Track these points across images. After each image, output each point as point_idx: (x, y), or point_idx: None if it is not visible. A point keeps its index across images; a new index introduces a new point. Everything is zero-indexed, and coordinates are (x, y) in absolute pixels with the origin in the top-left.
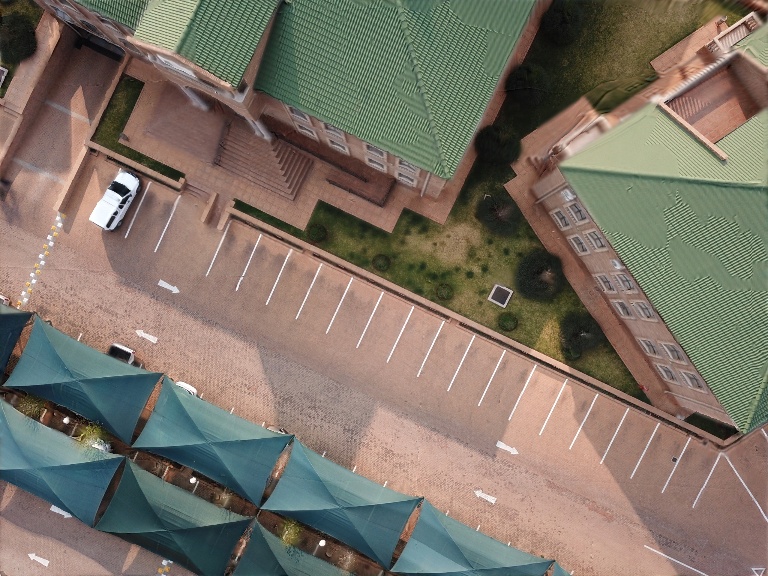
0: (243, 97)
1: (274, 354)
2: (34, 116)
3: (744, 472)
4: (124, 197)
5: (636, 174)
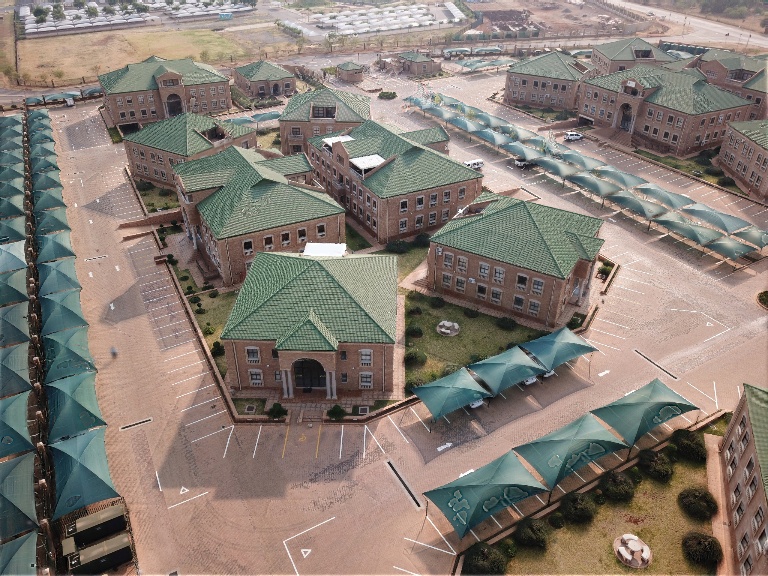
0: (641, 98)
1: None
2: (556, 128)
3: None
4: (578, 134)
5: None
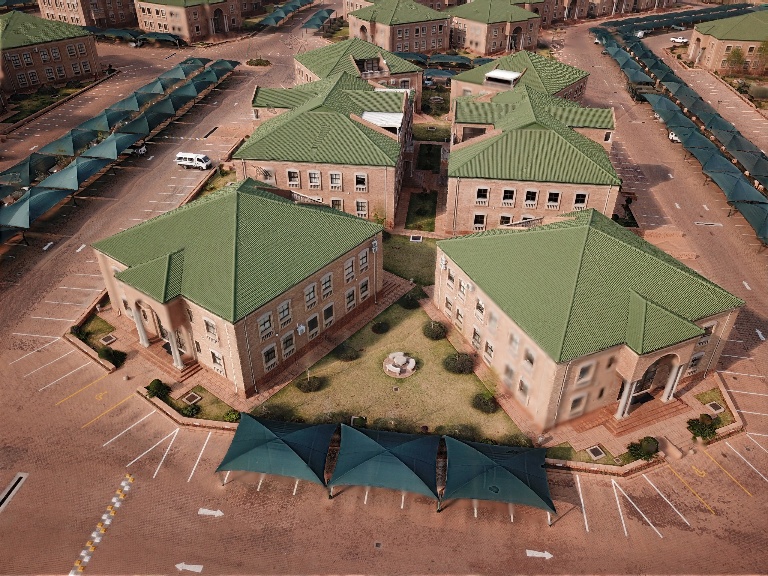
0: None
1: None
2: None
3: None
4: None
5: (1, 37)
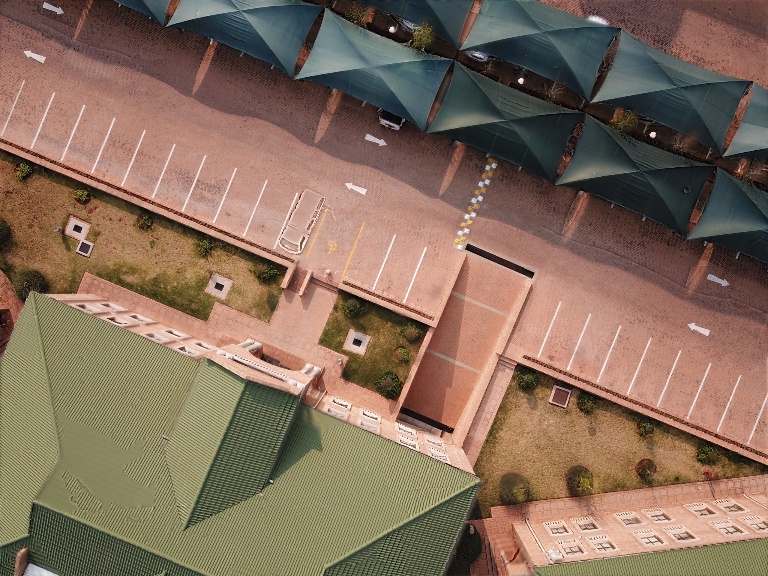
0: None
1: None
2: None
3: None
4: None
5: None
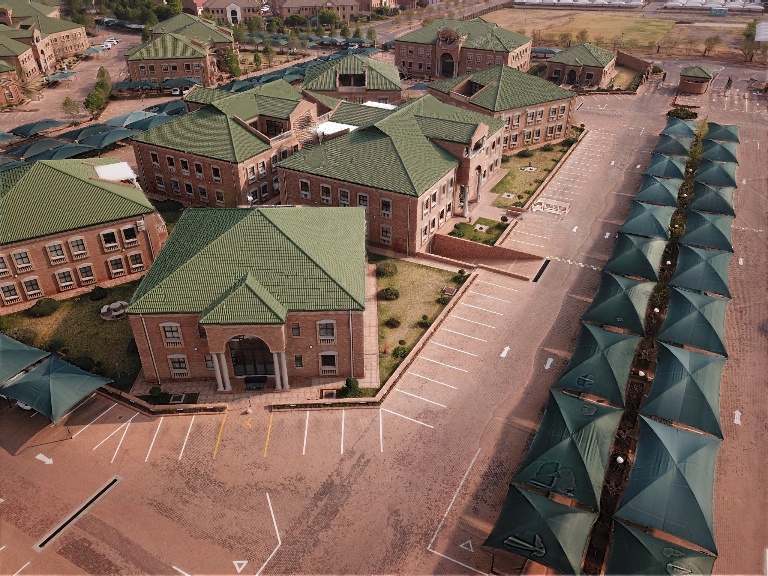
0: None
1: None
2: None
3: None
4: None
5: None
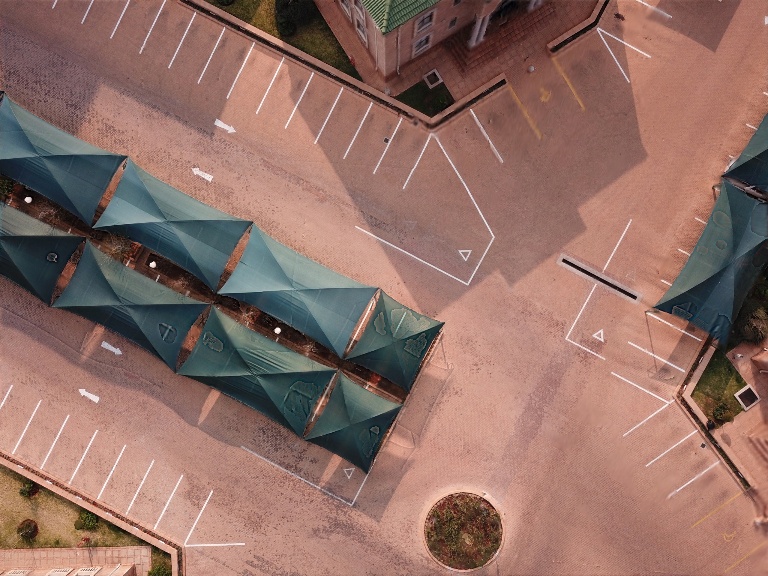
0: None
1: (2, 28)
2: None
3: (453, 153)
4: None
5: None
